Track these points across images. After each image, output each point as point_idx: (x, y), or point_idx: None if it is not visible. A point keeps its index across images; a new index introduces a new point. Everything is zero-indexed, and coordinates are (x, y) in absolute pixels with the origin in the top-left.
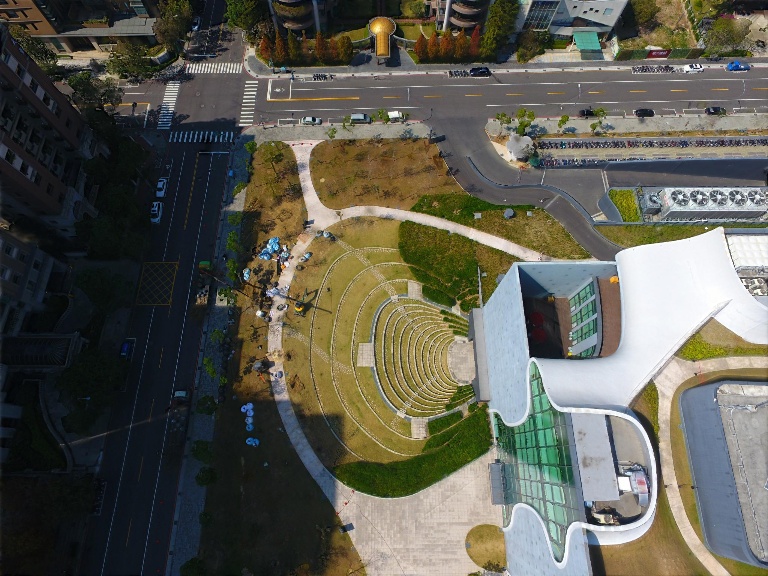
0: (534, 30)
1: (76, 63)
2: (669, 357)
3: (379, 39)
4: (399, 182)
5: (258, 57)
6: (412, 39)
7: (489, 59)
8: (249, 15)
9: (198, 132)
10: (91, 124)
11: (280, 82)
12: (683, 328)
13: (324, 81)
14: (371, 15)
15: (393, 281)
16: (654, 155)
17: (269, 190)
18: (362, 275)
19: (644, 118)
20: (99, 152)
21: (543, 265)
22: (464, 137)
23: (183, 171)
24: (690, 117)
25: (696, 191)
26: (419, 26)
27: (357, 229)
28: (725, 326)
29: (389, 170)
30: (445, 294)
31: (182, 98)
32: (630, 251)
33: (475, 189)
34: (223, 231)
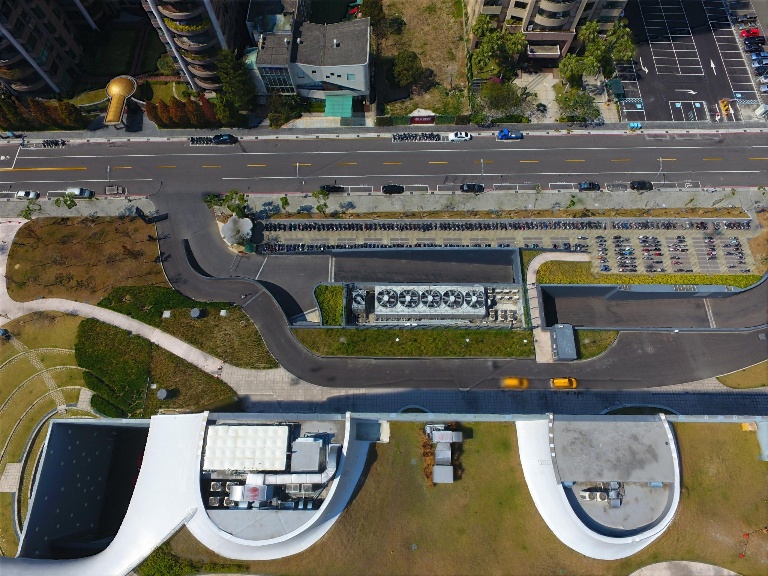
0: (282, 94)
1: None
2: (123, 575)
3: (112, 103)
4: (98, 270)
5: None
6: None
7: (235, 124)
8: None
9: None
10: None
11: (7, 148)
12: (156, 534)
13: (55, 148)
14: (122, 72)
15: (64, 388)
16: (391, 240)
17: None
18: (31, 381)
19: (391, 195)
20: None
21: (85, 422)
22: (188, 216)
23: None
24: (442, 194)
25: (407, 291)
26: (172, 84)
27: (37, 326)
28: (195, 537)
29: (92, 255)
30: (113, 406)
31: None
32: (152, 420)
33: (180, 279)
34: None
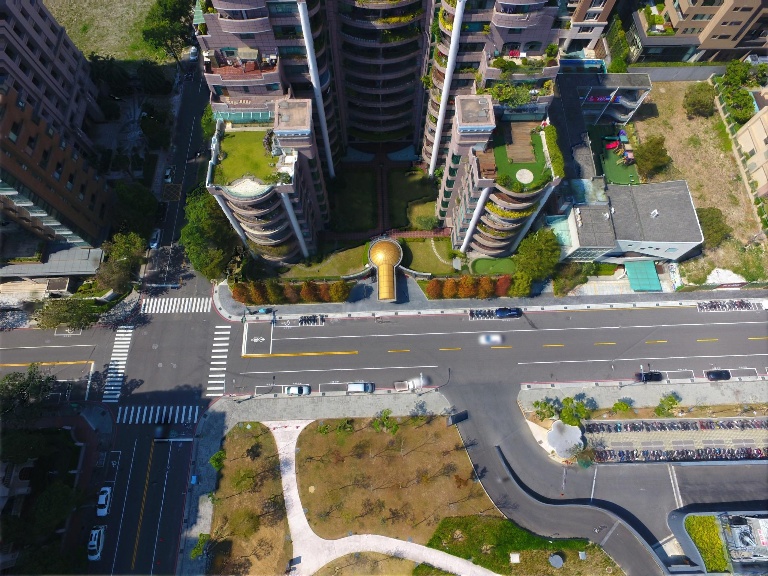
0: (576, 261)
1: (4, 299)
2: None
3: (382, 275)
4: (410, 494)
5: (231, 289)
6: (422, 262)
7: None
8: (216, 266)
9: (154, 407)
10: (2, 460)
11: (258, 327)
12: None
13: (313, 325)
14: (371, 227)
15: None
16: (734, 442)
17: (243, 505)
18: None
19: (718, 382)
20: (20, 469)
21: None
22: (491, 414)
23: (133, 471)
24: None
25: None
26: (431, 242)
27: (357, 573)
28: None
29: (397, 473)
30: None
31: (135, 353)
32: None
33: (509, 503)
34: (182, 571)
